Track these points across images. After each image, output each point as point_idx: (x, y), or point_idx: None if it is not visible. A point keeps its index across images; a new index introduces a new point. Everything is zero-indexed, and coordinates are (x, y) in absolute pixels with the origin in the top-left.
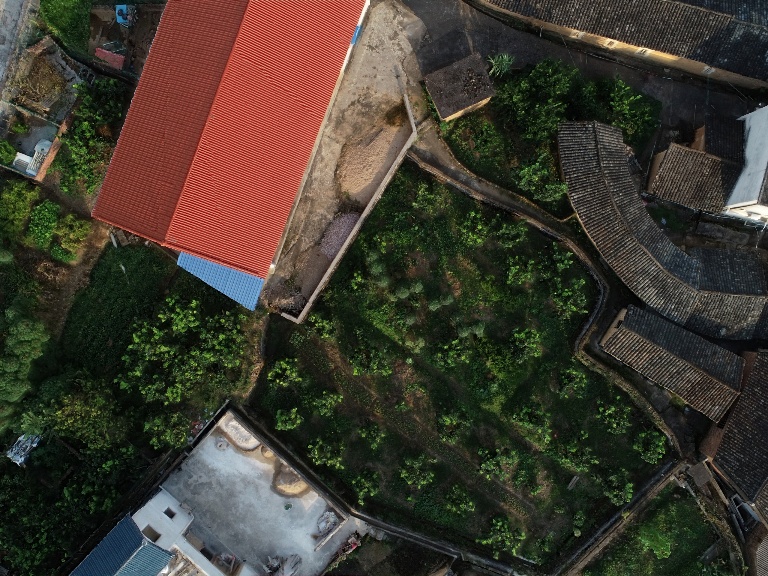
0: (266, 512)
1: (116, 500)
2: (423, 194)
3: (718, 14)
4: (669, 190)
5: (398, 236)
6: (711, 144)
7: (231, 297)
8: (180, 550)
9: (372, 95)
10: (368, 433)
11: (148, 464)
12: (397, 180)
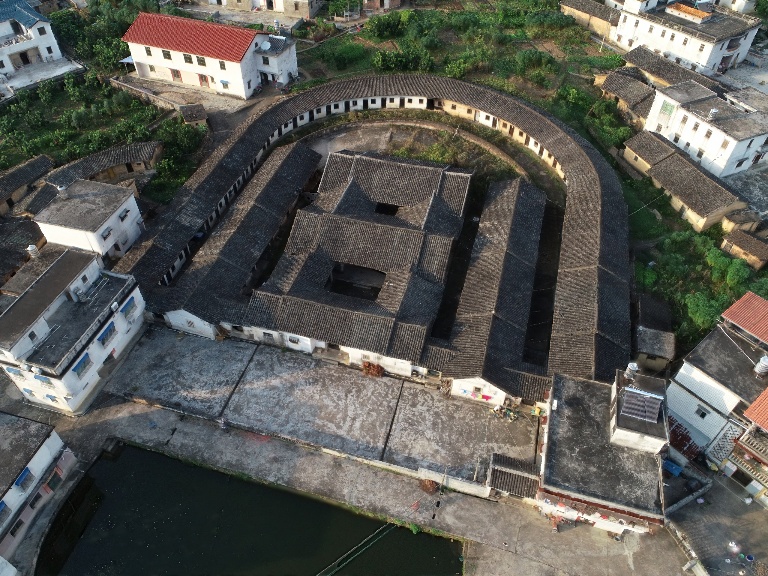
0: (33, 77)
1: (63, 37)
2: None
3: None
4: None
5: None
6: None
7: (127, 57)
8: (31, 40)
9: (204, 100)
10: (48, 96)
11: (73, 45)
12: None
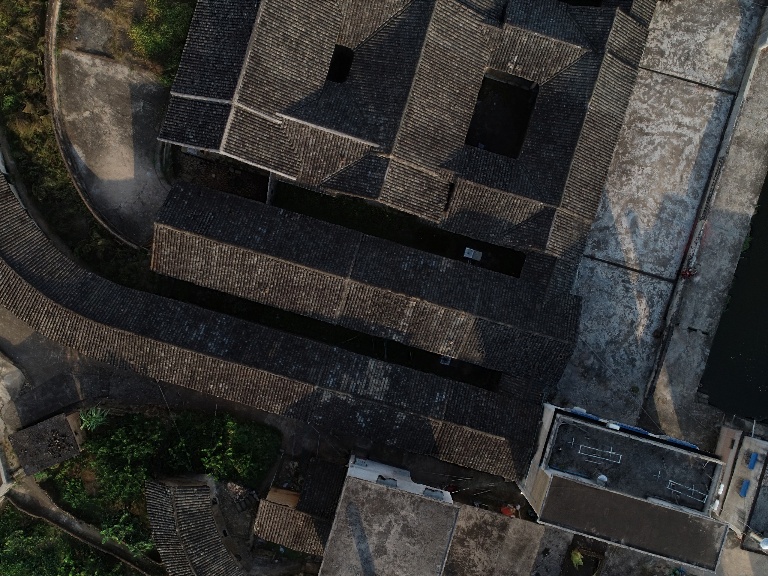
0: None
1: None
2: (19, 538)
3: (301, 383)
4: (270, 534)
5: (6, 567)
6: (305, 497)
7: None
8: None
9: None
10: None
11: None
12: (5, 513)
